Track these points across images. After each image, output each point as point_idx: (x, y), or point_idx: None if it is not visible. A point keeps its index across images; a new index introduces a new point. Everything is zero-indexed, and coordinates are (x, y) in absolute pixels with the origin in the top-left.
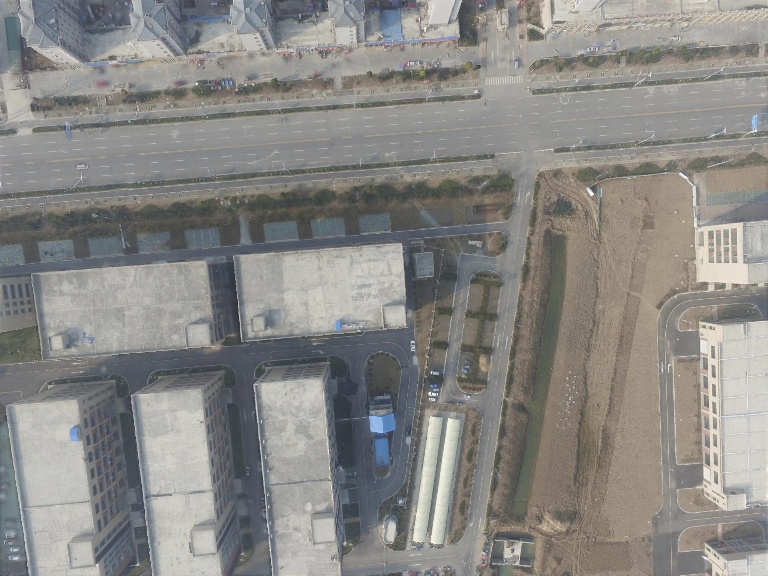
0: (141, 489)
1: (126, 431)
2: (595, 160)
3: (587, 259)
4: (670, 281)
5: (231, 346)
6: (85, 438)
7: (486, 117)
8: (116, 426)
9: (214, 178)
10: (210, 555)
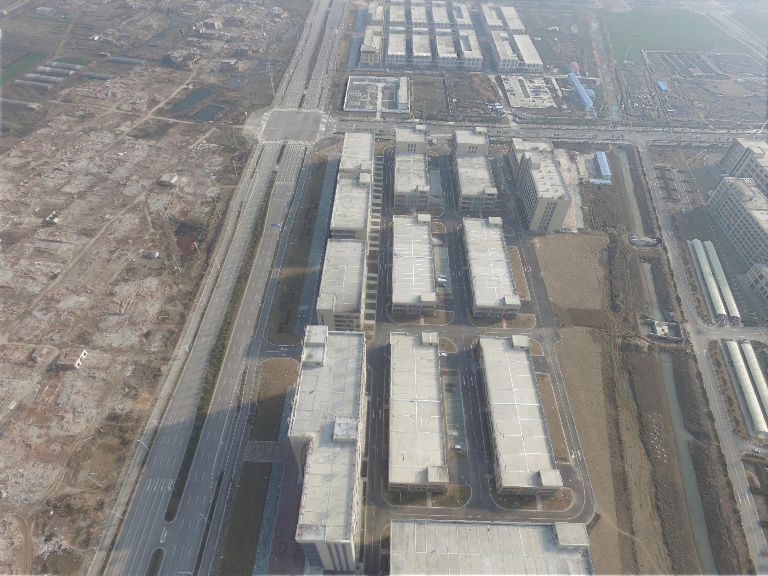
0: None
1: None
2: None
3: None
4: (592, 543)
5: None
6: None
7: None
8: None
9: None
10: None
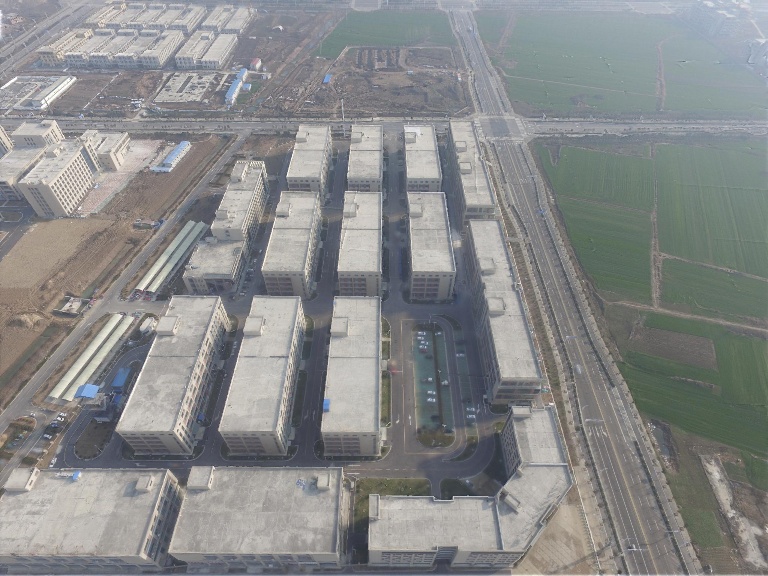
0: (323, 369)
1: None
2: None
3: None
4: None
5: None
6: None
7: None
8: None
9: None
10: None
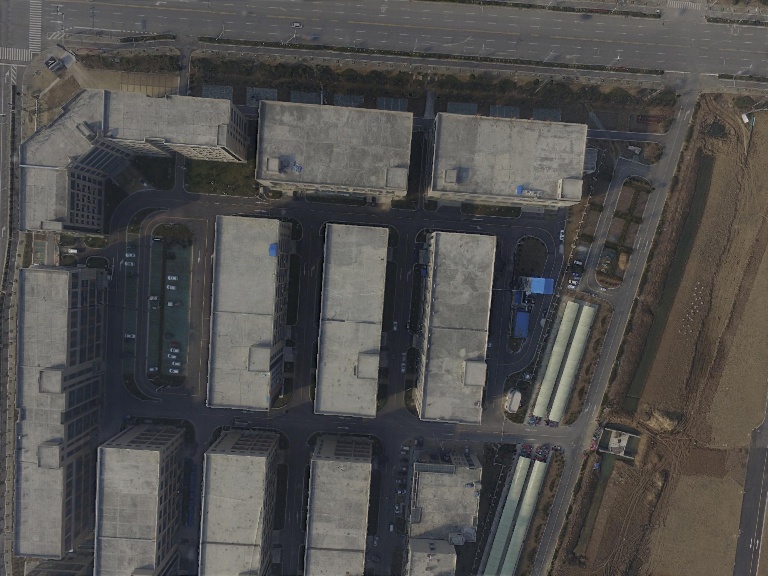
0: (297, 327)
1: (294, 271)
2: (754, 90)
3: (731, 180)
4: None
5: (399, 209)
6: (278, 257)
7: (662, 36)
8: (287, 264)
9: (412, 53)
10: (369, 382)
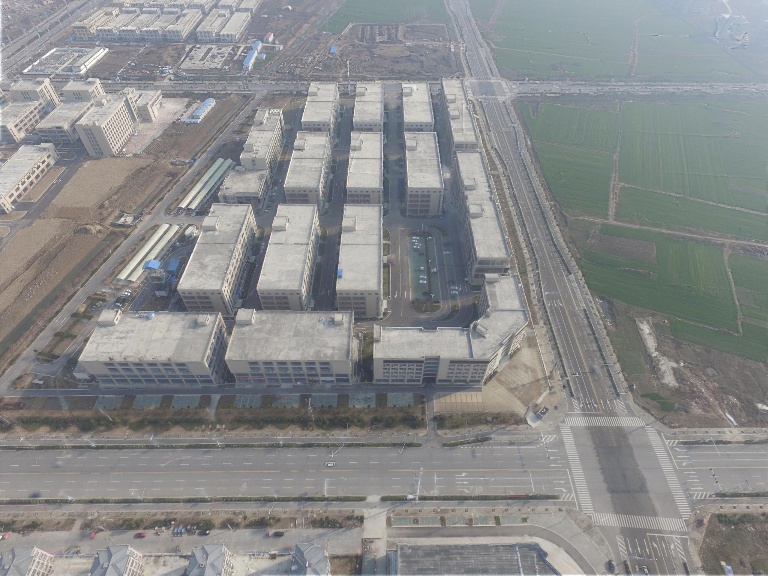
0: (335, 262)
1: None
2: None
3: None
4: None
5: None
6: None
7: None
8: None
9: (223, 446)
10: None
